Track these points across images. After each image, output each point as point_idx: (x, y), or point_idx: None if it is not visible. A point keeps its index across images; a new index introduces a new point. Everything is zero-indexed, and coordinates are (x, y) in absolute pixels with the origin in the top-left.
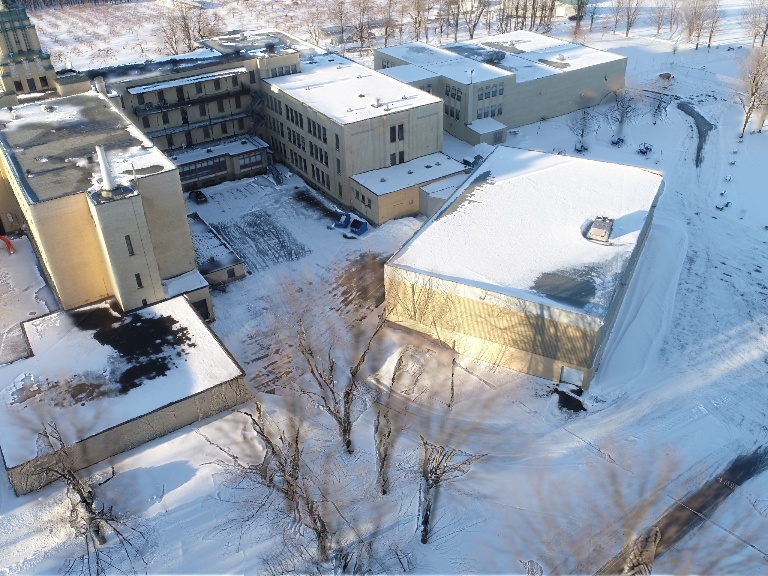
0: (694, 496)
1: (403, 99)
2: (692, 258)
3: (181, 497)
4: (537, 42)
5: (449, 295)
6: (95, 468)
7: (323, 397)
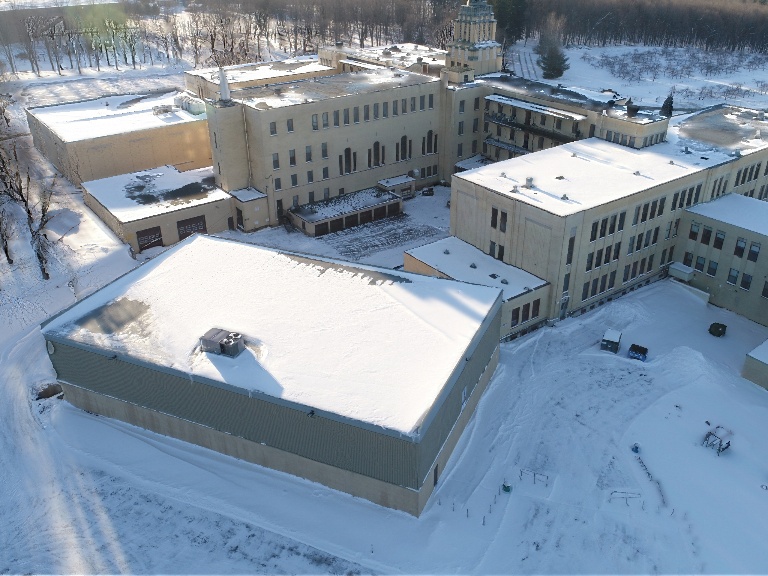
0: None
1: (561, 197)
2: (329, 562)
3: None
4: None
5: None
6: (89, 212)
7: (28, 218)
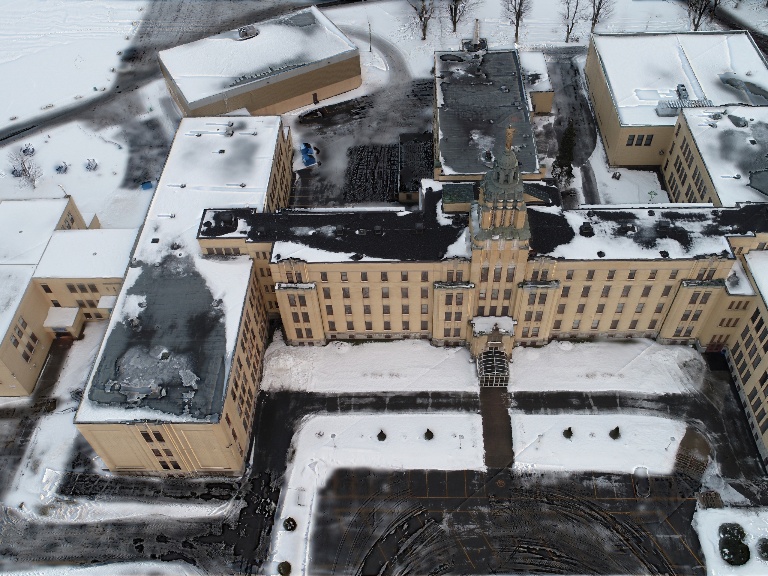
0: (336, 4)
1: (202, 134)
2: None
3: None
4: None
5: None
6: None
7: None
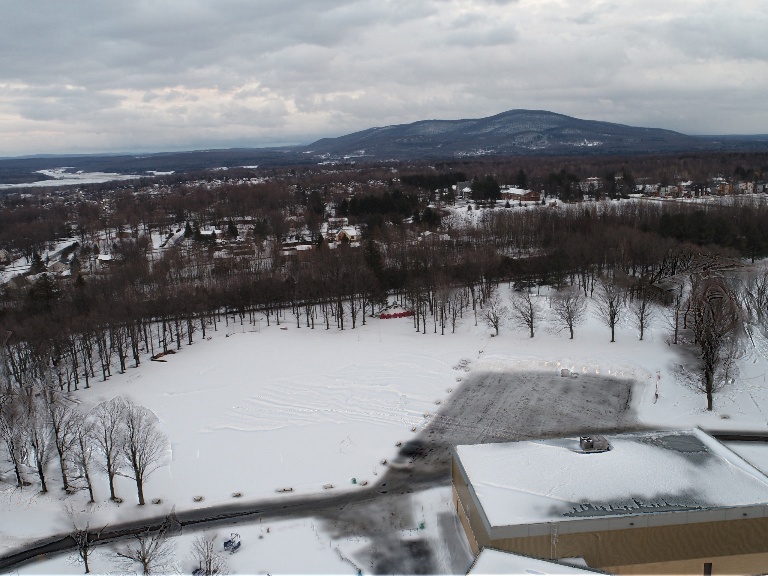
0: None
1: None
2: None
3: None
4: None
5: None
6: None
7: None
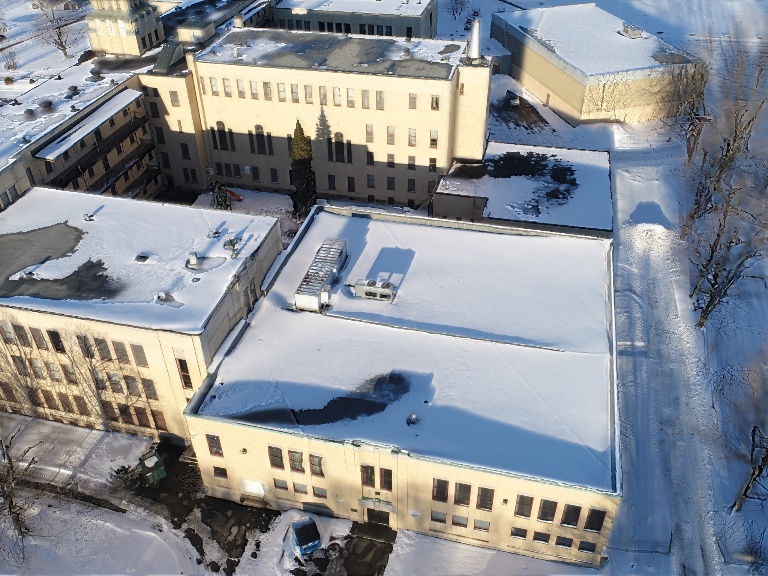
0: None
1: None
2: None
3: (672, 211)
4: None
5: (628, 82)
6: (614, 225)
7: None
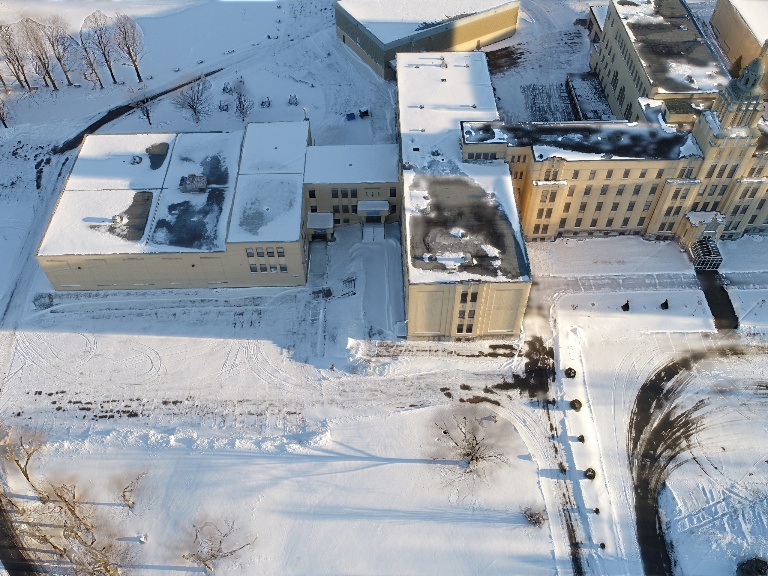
0: None
1: (420, 66)
2: None
3: None
4: (87, 212)
5: None
6: None
7: None
